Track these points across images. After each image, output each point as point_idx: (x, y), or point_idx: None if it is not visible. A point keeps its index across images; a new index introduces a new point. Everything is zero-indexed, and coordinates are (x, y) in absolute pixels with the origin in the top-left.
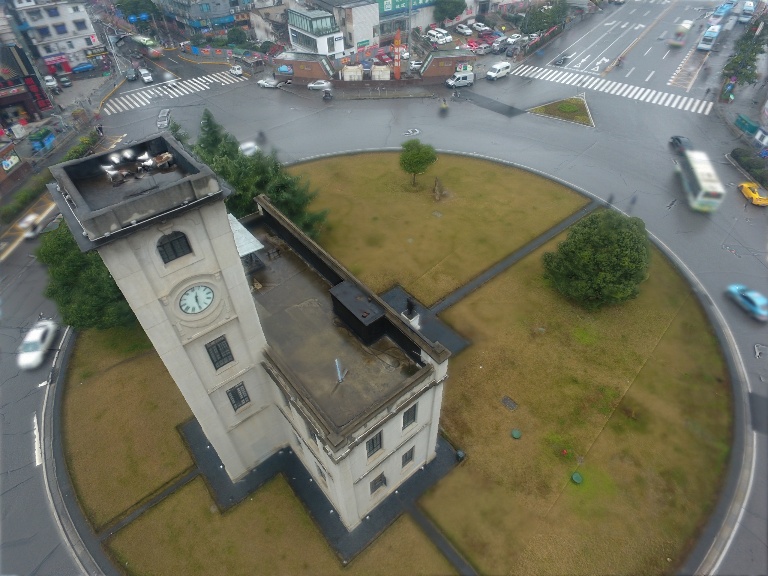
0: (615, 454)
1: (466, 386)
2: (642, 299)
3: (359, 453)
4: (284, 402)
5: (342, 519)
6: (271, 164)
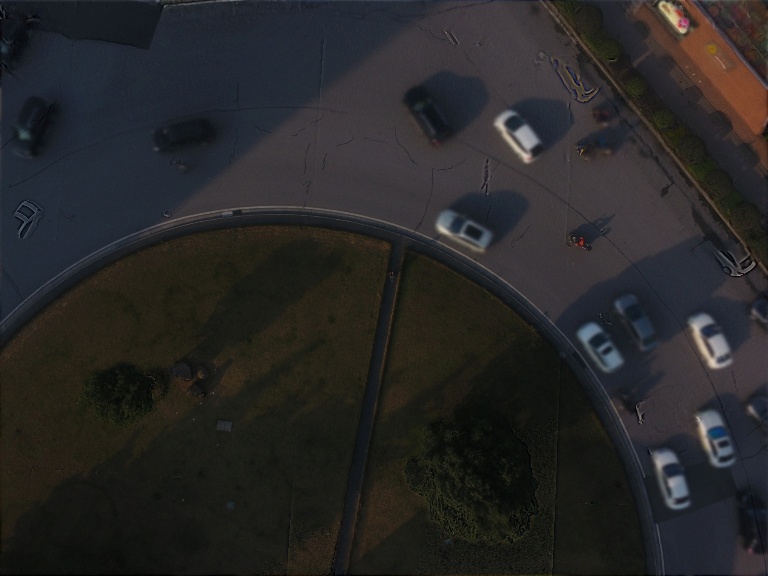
0: None
1: None
2: (520, 418)
3: None
4: None
5: None
6: None
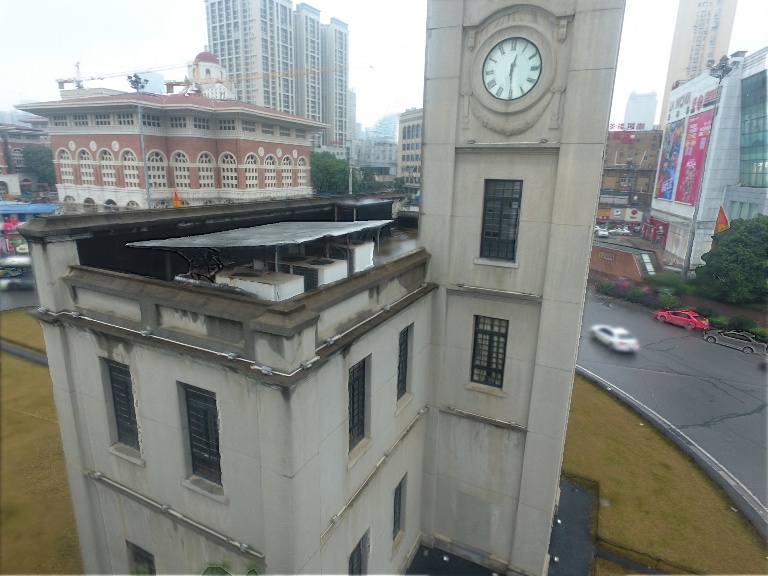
0: None
1: None
2: None
3: None
4: None
5: None
6: None
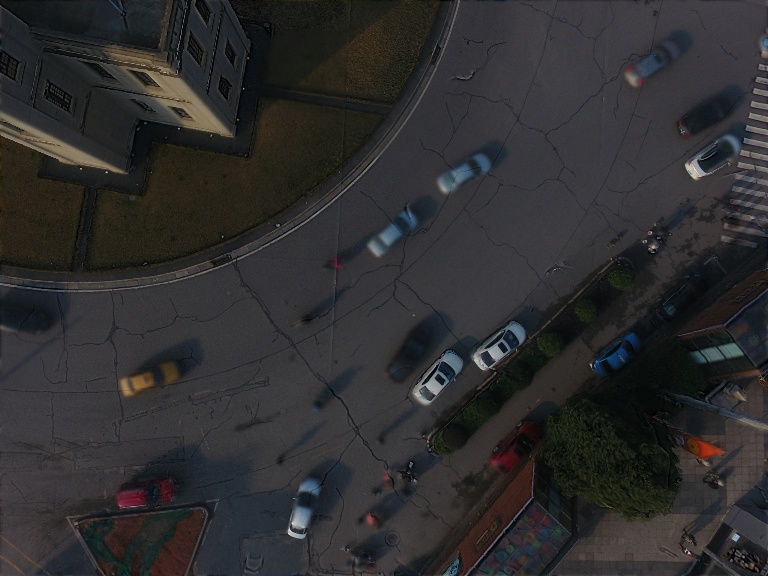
0: None
1: None
2: None
3: (189, 63)
4: (99, 75)
5: (222, 133)
6: None
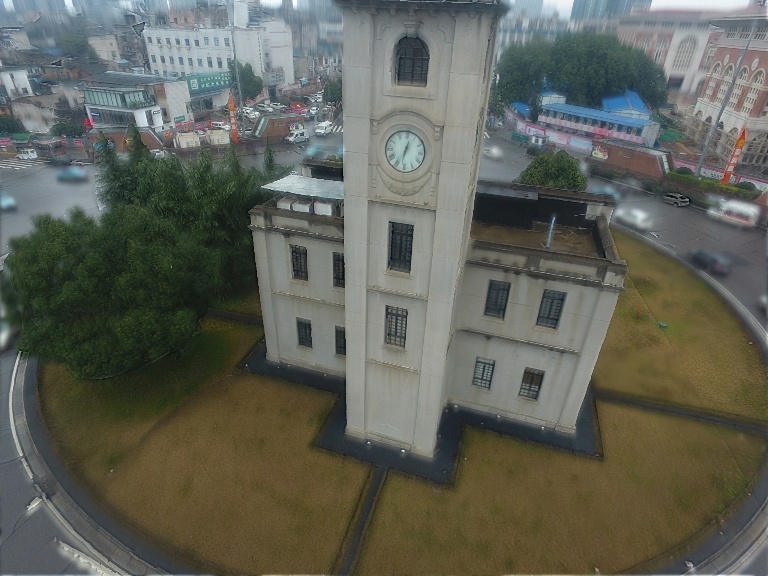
0: (663, 304)
1: None
2: None
3: None
4: (484, 309)
5: (562, 424)
6: (240, 168)
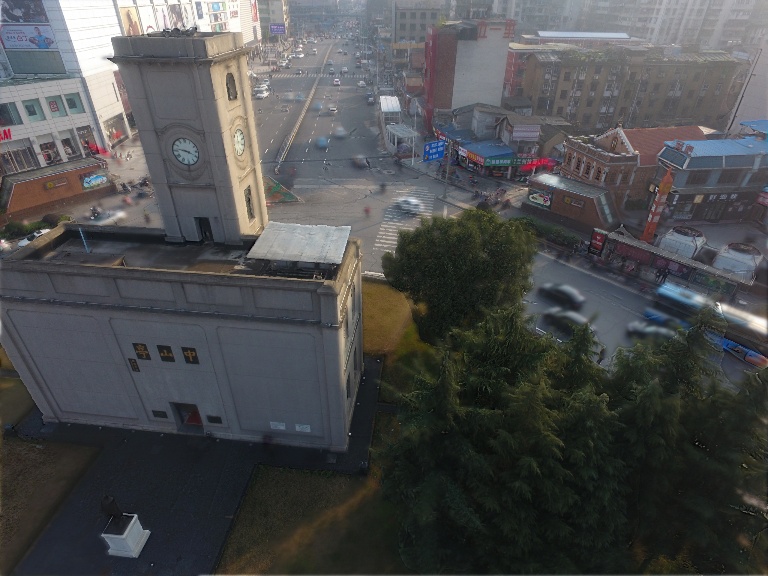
0: None
1: (6, 510)
2: None
3: None
4: None
5: None
6: (534, 439)
